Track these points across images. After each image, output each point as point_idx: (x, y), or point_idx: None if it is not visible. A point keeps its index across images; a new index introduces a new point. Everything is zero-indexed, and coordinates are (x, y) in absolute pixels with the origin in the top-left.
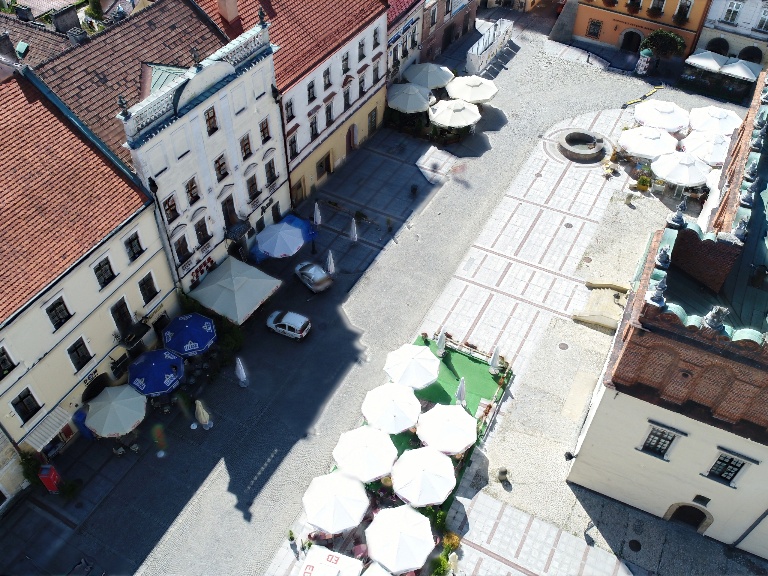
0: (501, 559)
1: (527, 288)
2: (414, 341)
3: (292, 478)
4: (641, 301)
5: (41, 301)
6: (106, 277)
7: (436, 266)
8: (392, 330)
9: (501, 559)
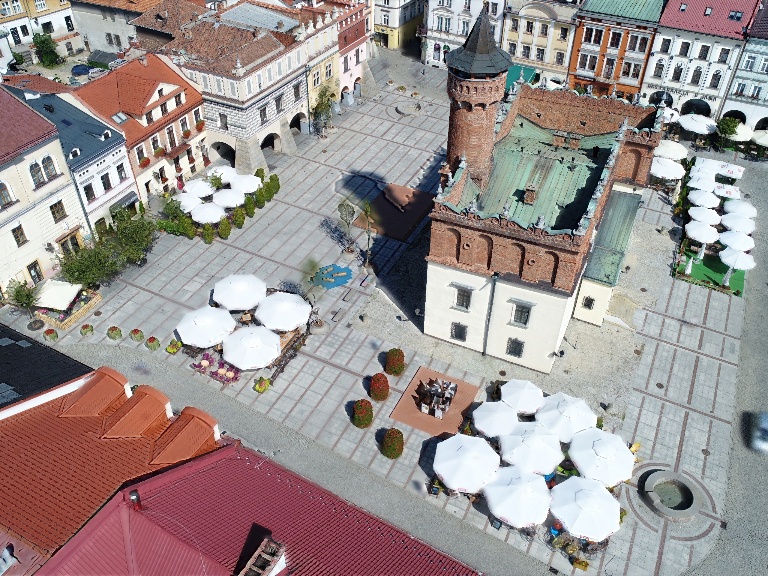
0: (653, 210)
1: (680, 329)
2: (744, 294)
3: (767, 235)
4: (662, 121)
5: None
6: None
7: (759, 346)
8: (763, 301)
9: (653, 210)
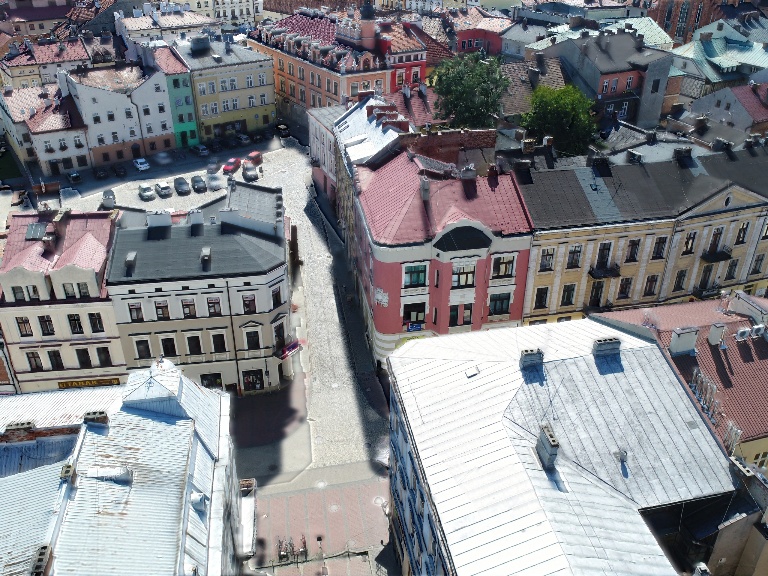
0: None
1: None
2: None
3: None
4: None
5: (185, 0)
6: (199, 7)
7: None
8: None
9: None
